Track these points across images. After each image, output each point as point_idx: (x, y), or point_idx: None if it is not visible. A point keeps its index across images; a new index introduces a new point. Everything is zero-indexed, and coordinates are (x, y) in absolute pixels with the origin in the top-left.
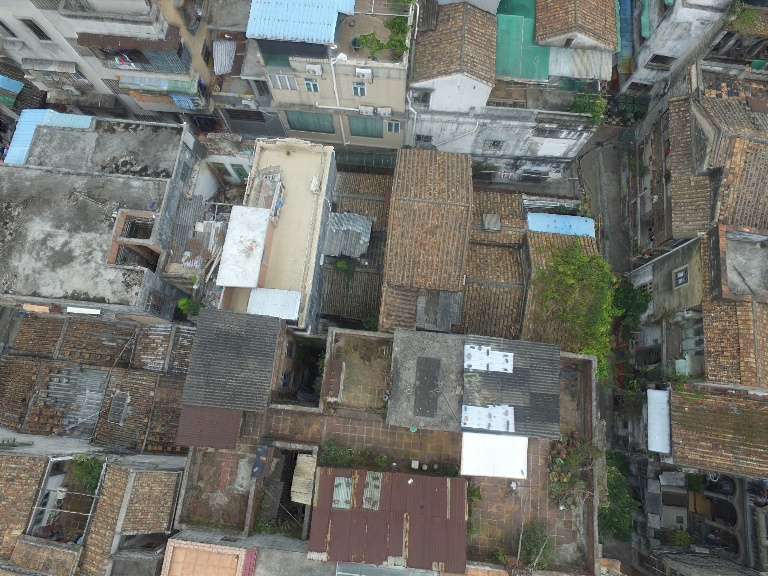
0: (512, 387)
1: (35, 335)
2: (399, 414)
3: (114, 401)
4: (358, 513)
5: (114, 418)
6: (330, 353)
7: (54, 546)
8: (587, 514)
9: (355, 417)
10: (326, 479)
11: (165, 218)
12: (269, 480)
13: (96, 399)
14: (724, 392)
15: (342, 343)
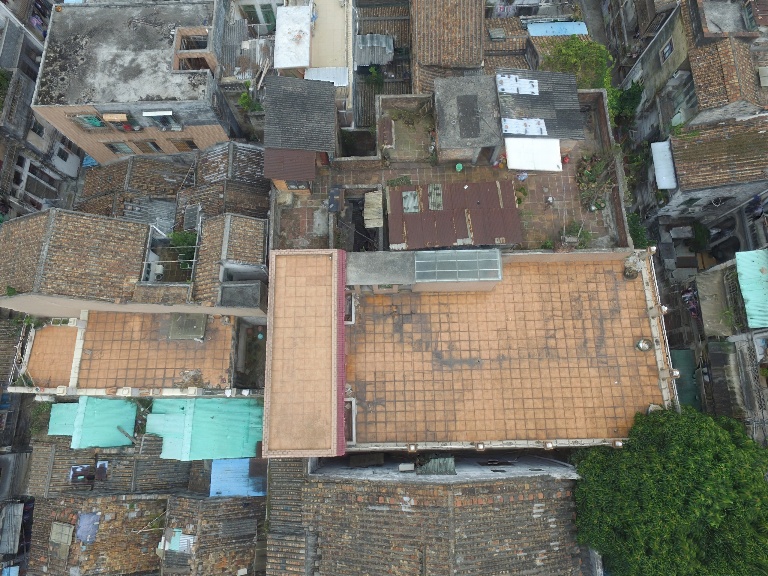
0: (540, 106)
1: (102, 180)
2: (448, 139)
3: (186, 213)
4: (426, 214)
5: (189, 226)
6: (379, 115)
7: (169, 284)
8: (615, 210)
9: (408, 168)
10: (395, 194)
11: (216, 33)
12: (342, 223)
13: (166, 227)
14: (716, 125)
15: (387, 115)
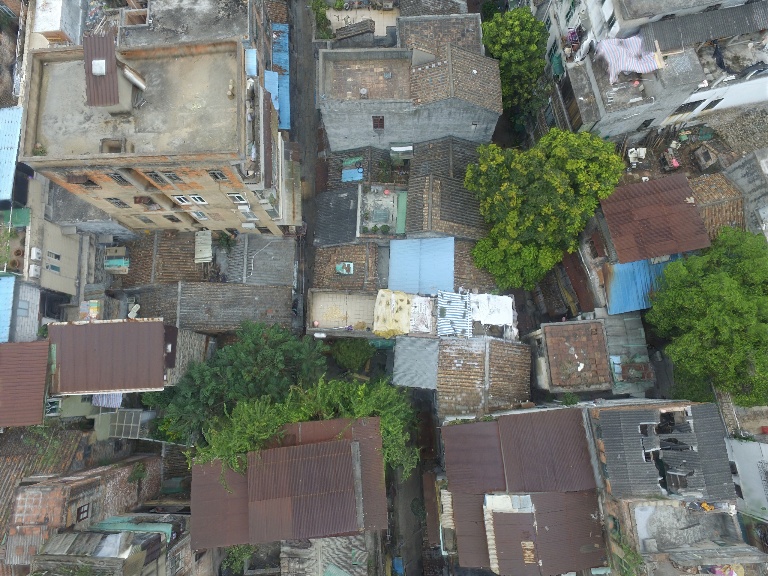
0: None
1: (267, 9)
2: None
3: None
4: None
5: None
6: None
7: None
8: None
9: None
10: None
11: None
12: None
13: None
14: None
15: None
